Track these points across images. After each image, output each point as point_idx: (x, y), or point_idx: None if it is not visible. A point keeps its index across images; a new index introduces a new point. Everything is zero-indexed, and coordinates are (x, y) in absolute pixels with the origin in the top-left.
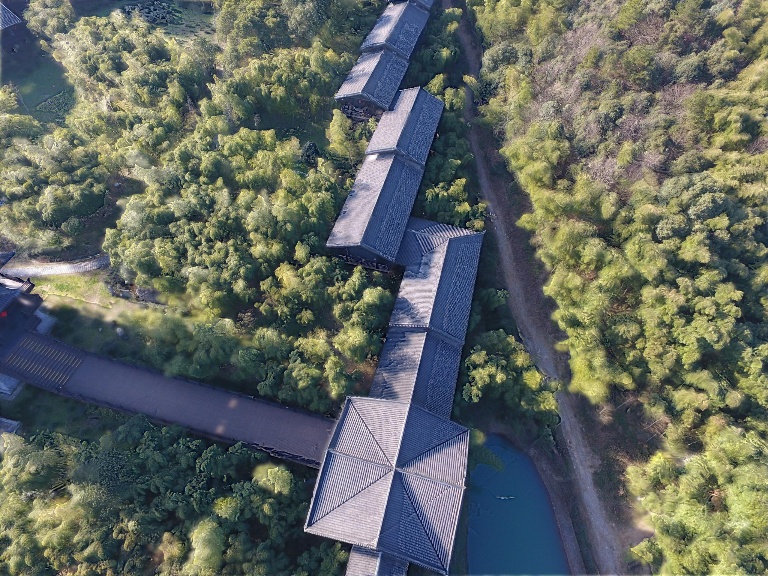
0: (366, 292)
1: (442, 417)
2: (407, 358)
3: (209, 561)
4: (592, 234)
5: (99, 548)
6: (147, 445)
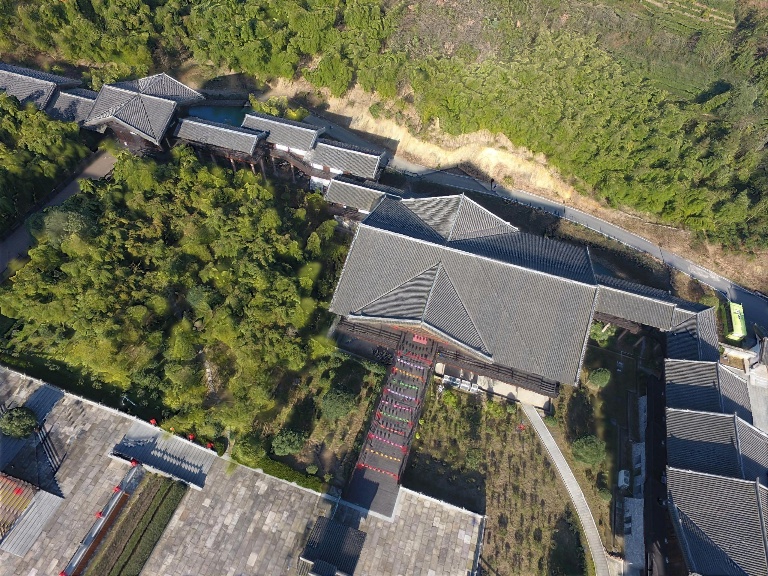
0: (3, 100)
1: (122, 82)
2: (74, 106)
3: (153, 179)
4: (38, 7)
5: (118, 229)
6: (55, 209)
